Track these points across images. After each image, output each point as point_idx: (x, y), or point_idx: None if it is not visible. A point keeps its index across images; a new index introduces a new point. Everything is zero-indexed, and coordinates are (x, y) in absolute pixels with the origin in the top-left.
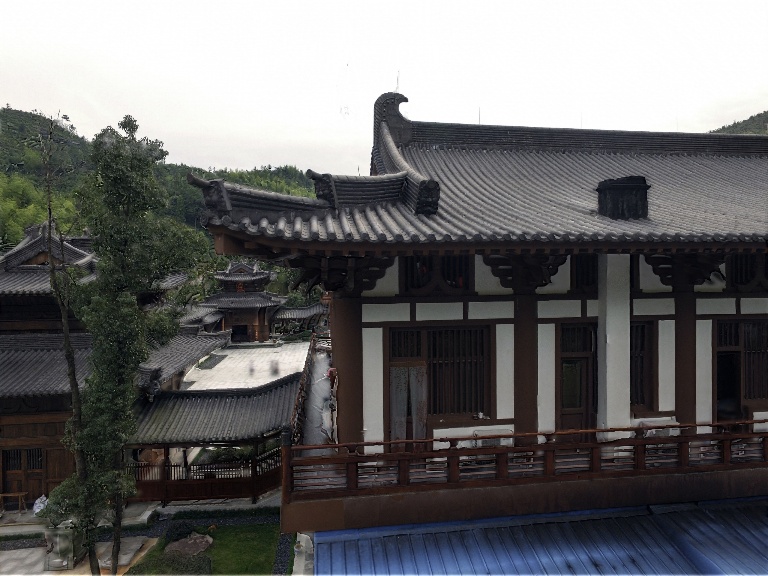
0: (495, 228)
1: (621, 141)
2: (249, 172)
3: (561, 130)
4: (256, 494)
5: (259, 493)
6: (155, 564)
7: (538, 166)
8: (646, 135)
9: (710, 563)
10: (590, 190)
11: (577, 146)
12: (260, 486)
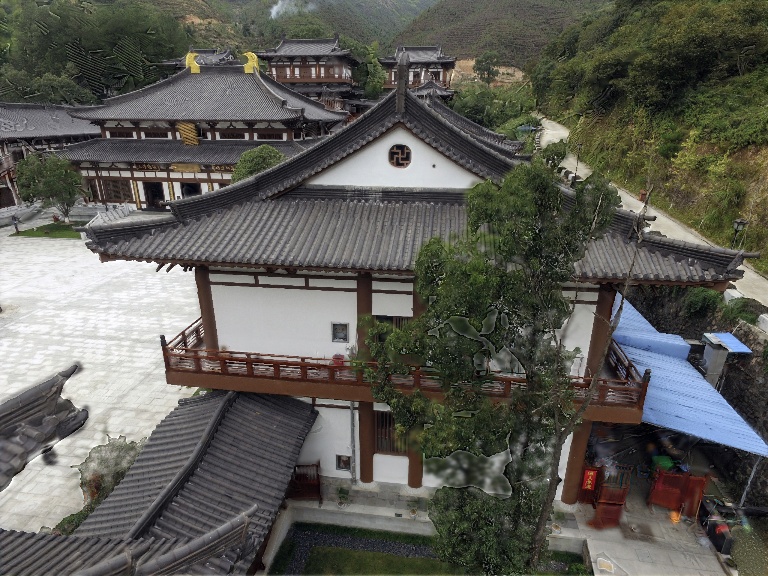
0: None
1: None
2: None
3: None
4: (261, 559)
5: (262, 555)
6: None
7: None
8: None
9: None
10: None
11: None
12: (261, 547)
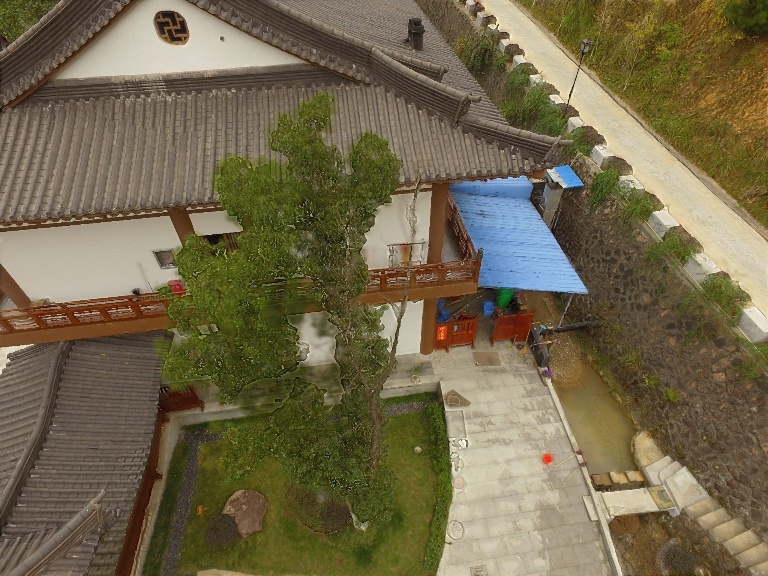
0: (470, 90)
1: None
2: None
3: None
4: (155, 471)
5: (155, 468)
6: (307, 503)
7: None
8: None
9: (462, 186)
10: (320, 4)
11: None
12: (152, 463)
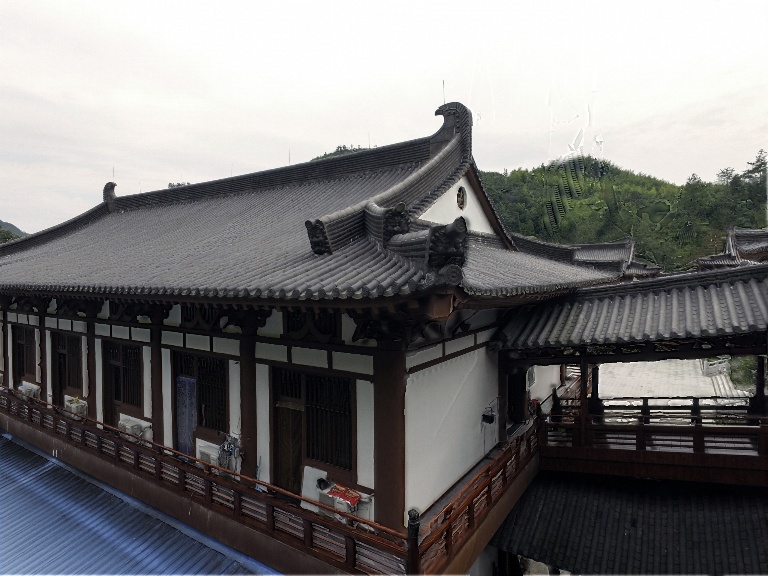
0: None
1: (197, 192)
2: (535, 169)
3: (169, 190)
4: None
5: None
6: None
7: (126, 222)
8: (210, 184)
9: None
10: None
11: (176, 200)
12: None
